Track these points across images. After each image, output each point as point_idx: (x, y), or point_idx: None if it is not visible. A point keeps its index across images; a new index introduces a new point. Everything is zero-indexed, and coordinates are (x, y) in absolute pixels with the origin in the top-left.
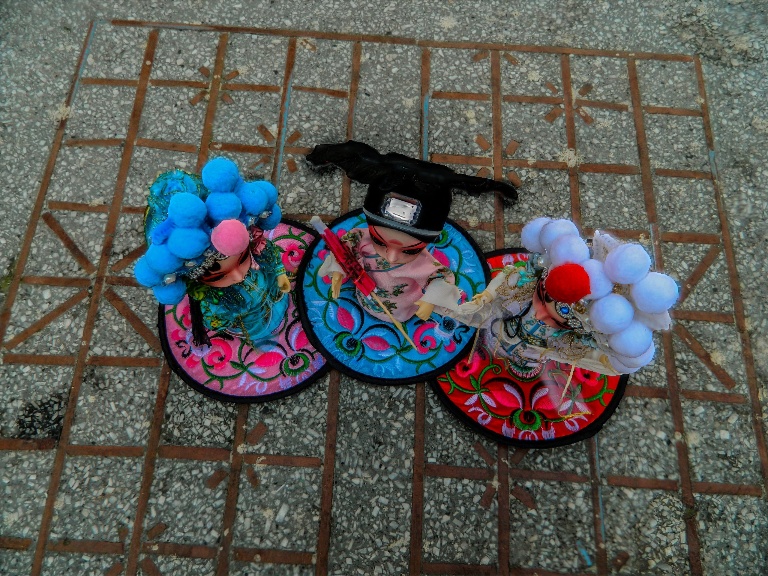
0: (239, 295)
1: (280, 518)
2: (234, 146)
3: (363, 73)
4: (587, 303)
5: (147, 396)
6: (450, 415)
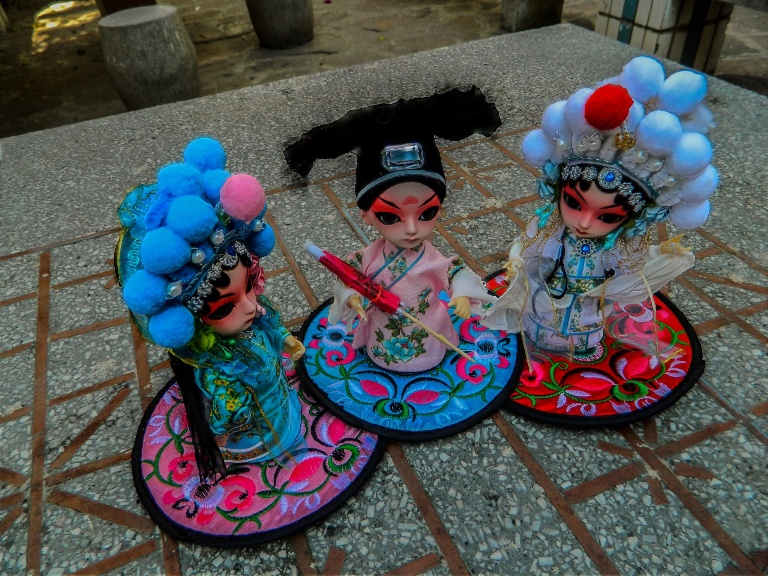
0: None
1: None
2: None
3: (275, 214)
4: None
5: None
6: (550, 430)
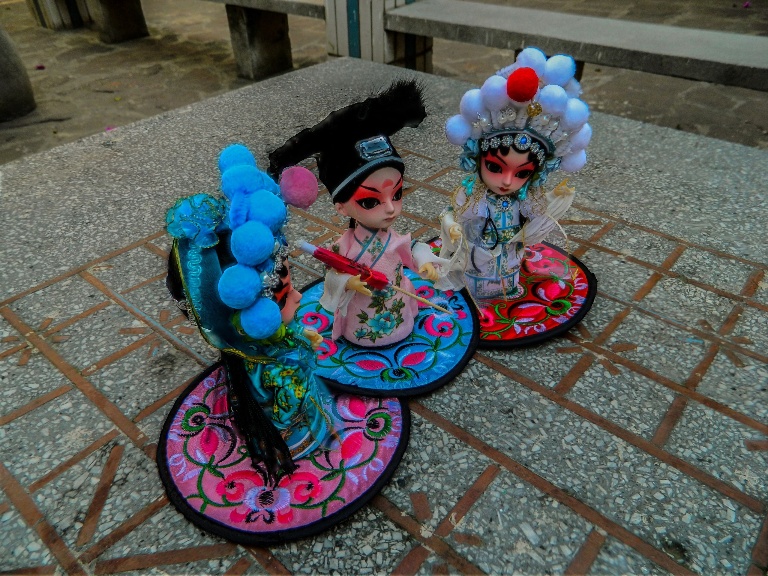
0: None
1: (534, 538)
2: (110, 357)
3: None
4: None
5: None
6: (519, 352)
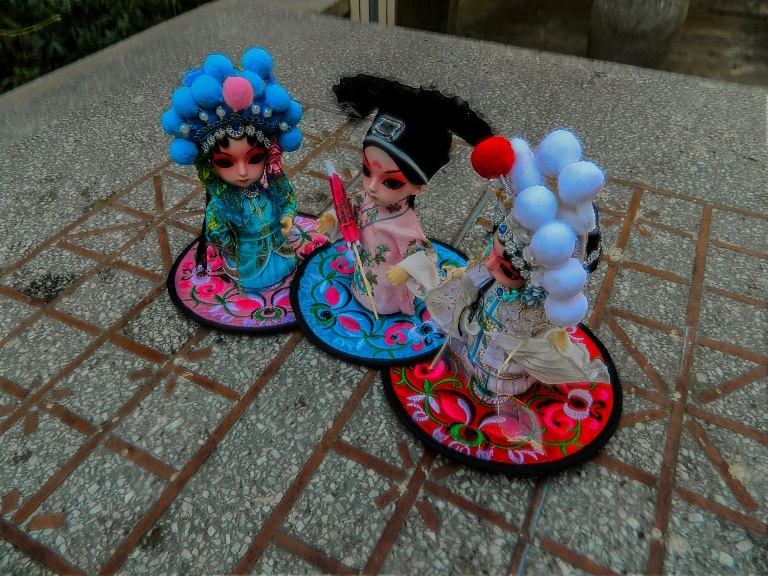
0: (241, 204)
1: (170, 428)
2: (318, 174)
3: None
4: (515, 198)
5: (135, 298)
6: (388, 407)
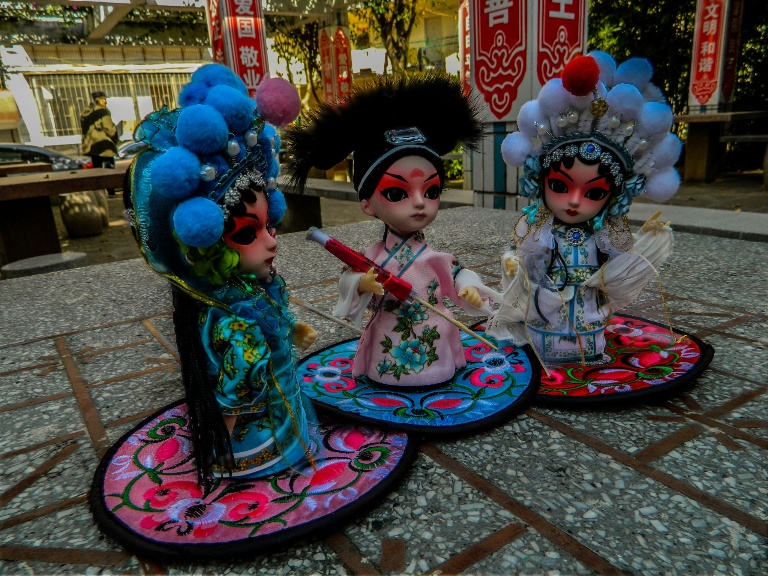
0: None
1: None
2: (122, 377)
3: None
4: None
5: None
6: (590, 414)
